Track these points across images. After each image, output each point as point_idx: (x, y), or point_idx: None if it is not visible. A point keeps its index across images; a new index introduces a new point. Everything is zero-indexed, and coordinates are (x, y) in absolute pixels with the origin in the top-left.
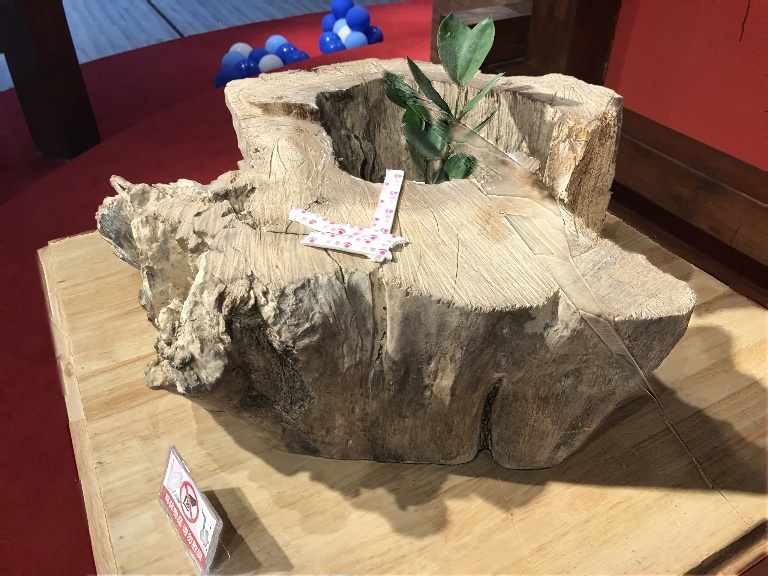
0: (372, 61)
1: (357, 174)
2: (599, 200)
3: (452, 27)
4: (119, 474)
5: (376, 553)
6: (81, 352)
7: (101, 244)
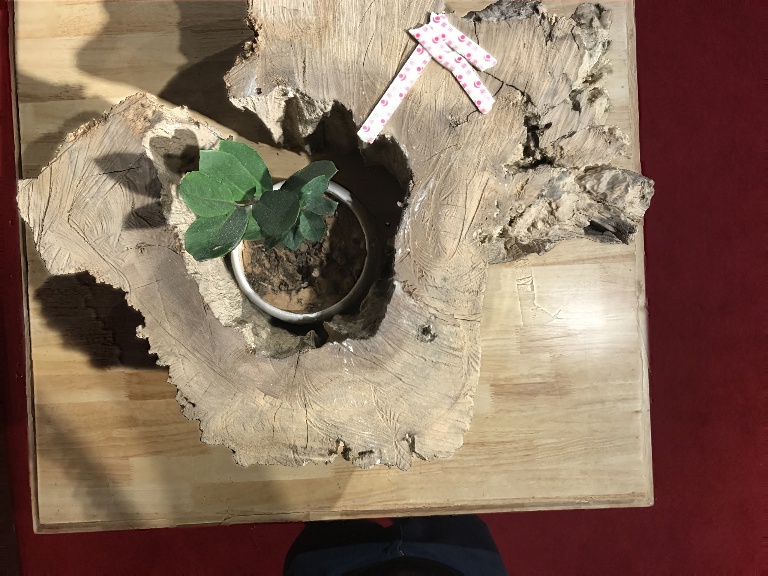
0: (246, 451)
1: (335, 321)
2: None
3: (207, 253)
4: None
5: (470, 1)
6: (630, 292)
7: (594, 461)
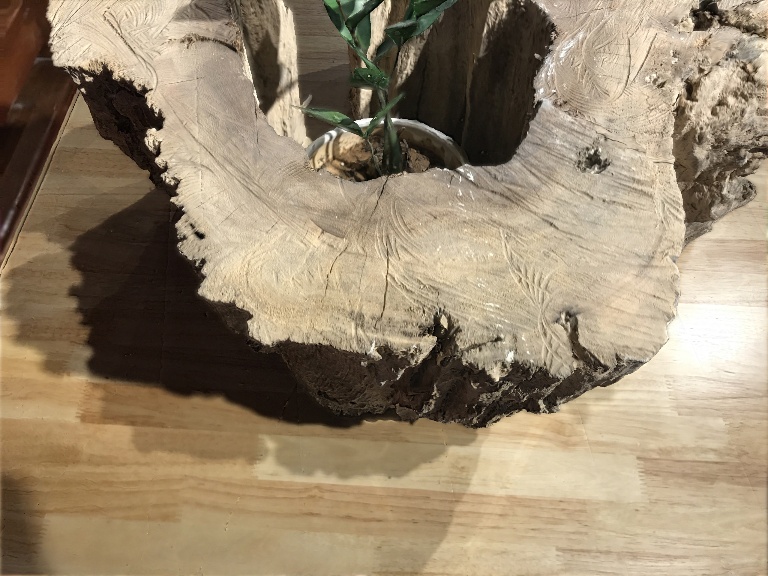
0: (272, 317)
1: None
2: None
3: None
4: (762, 181)
5: None
6: None
7: None
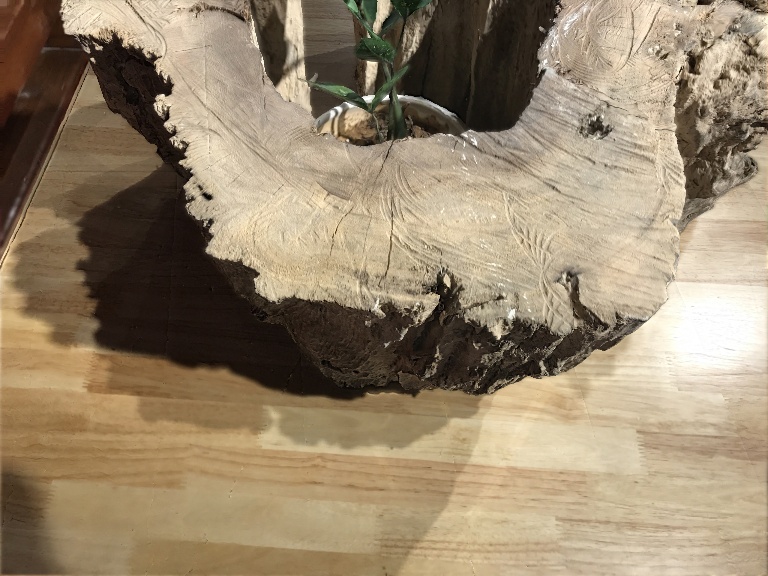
0: (278, 275)
1: None
2: None
3: None
4: (765, 163)
5: None
6: None
7: None
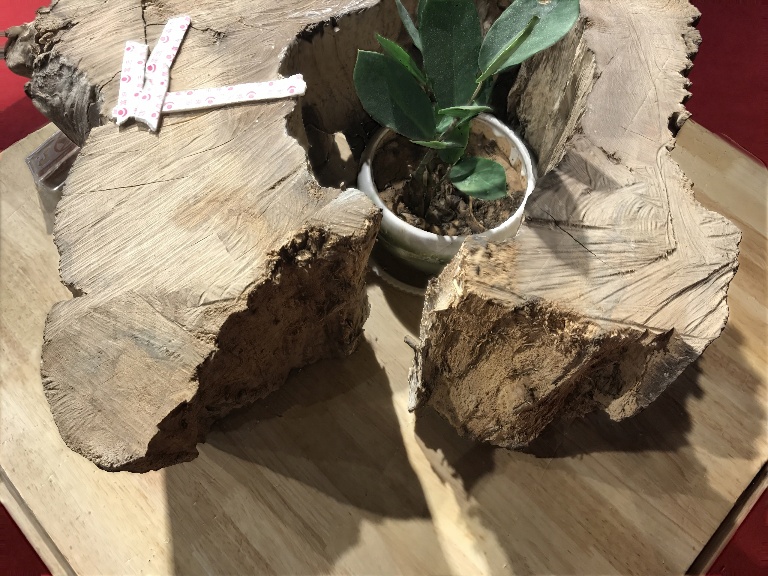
0: None
1: None
2: (516, 390)
3: None
4: None
5: None
6: None
7: None
